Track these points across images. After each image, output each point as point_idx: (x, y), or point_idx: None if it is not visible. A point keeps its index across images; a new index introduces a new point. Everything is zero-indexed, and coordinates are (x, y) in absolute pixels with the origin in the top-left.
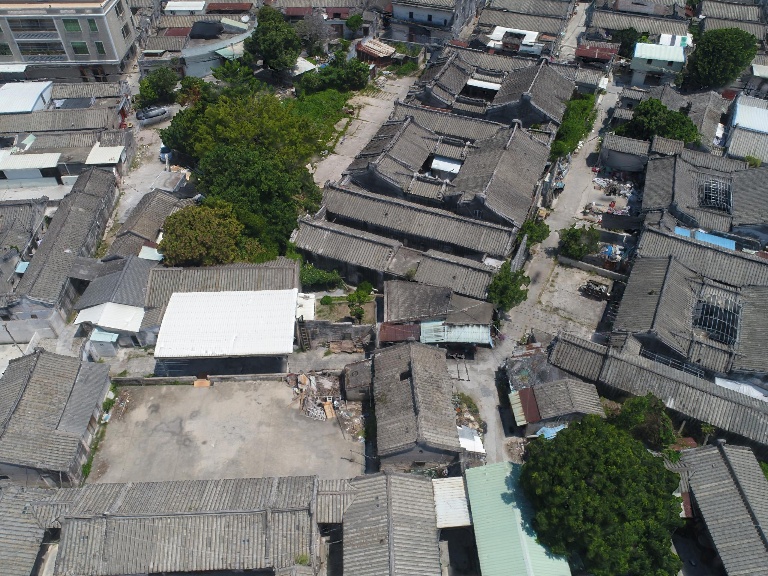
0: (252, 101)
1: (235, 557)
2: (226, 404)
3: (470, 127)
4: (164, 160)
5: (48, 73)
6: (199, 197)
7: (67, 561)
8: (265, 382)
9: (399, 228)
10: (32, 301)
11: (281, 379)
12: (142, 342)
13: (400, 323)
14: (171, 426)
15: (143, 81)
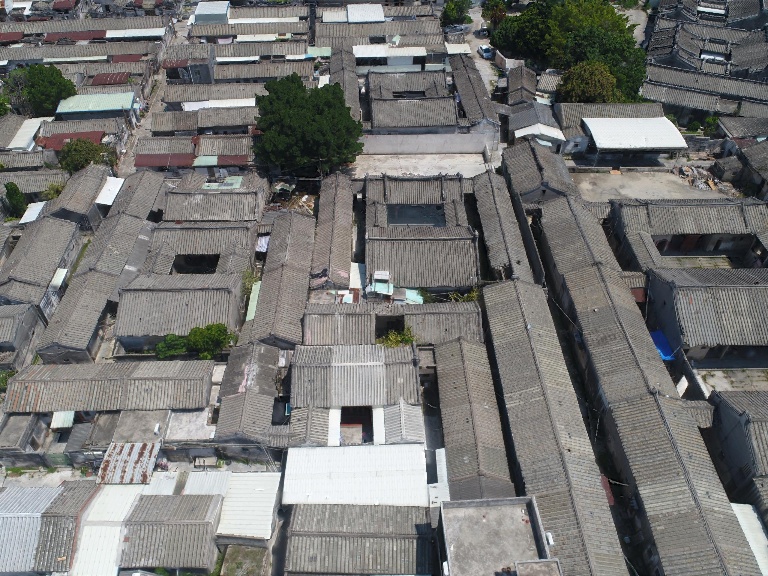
0: (584, 4)
1: (728, 227)
2: (639, 182)
3: (722, 33)
4: (487, 58)
5: (360, 2)
6: (549, 72)
7: (630, 226)
8: (657, 173)
9: (709, 89)
10: (488, 122)
11: (668, 171)
12: (562, 150)
13: (743, 138)
14: (611, 192)
15: (449, 4)
